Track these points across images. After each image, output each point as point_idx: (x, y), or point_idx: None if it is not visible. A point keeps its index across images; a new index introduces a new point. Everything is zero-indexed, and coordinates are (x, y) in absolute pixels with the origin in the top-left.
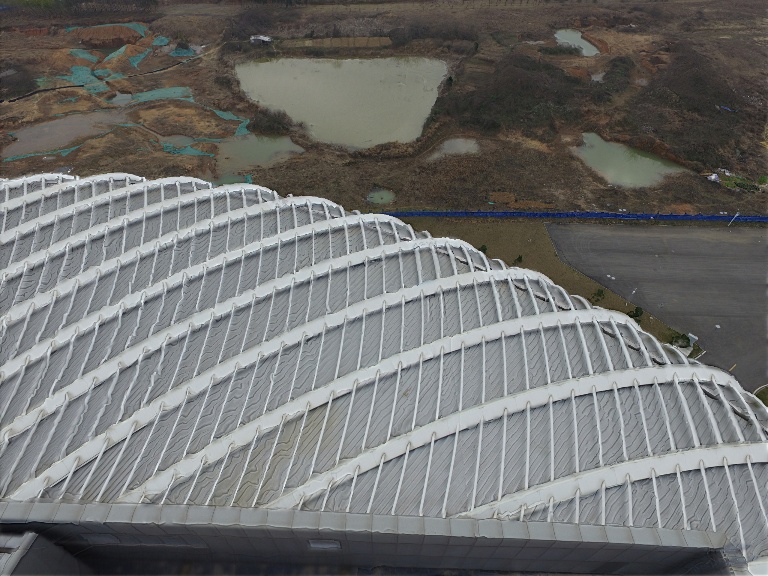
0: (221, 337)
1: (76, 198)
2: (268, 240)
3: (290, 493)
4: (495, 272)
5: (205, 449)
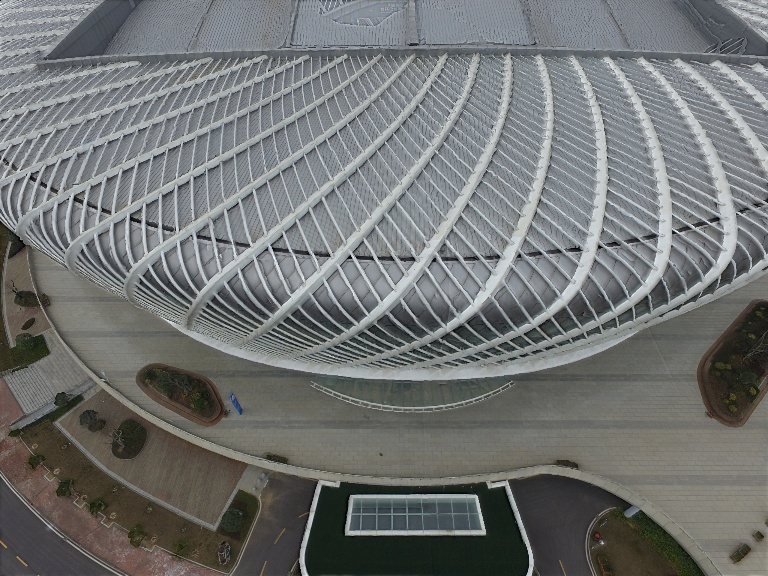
0: (232, 108)
1: (404, 211)
2: (201, 167)
3: (197, 61)
4: (26, 169)
5: (231, 67)
